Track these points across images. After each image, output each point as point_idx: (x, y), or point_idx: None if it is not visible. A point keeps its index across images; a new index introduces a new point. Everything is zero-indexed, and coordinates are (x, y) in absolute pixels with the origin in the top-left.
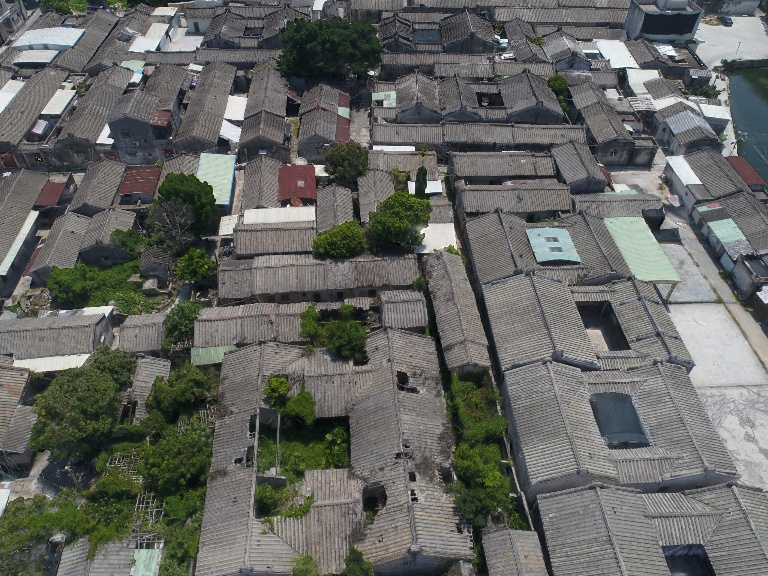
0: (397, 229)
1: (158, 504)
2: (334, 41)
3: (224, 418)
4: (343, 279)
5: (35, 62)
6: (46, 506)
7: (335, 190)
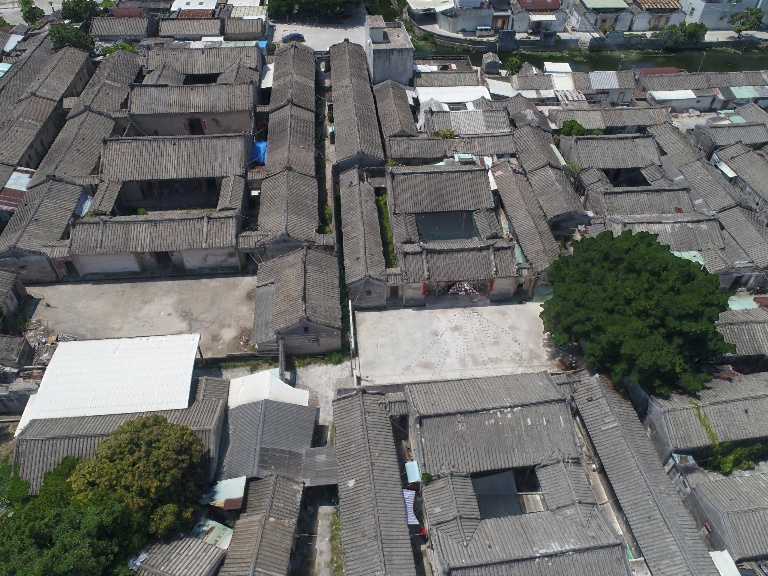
0: None
1: None
2: None
3: None
4: None
5: None
6: None
7: None
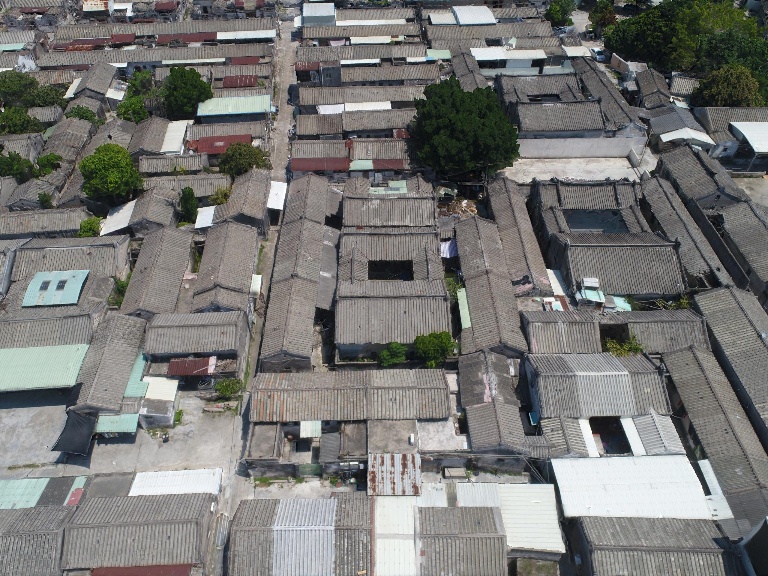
0: None
1: None
2: None
3: None
4: None
5: (431, 19)
6: None
7: (194, 156)
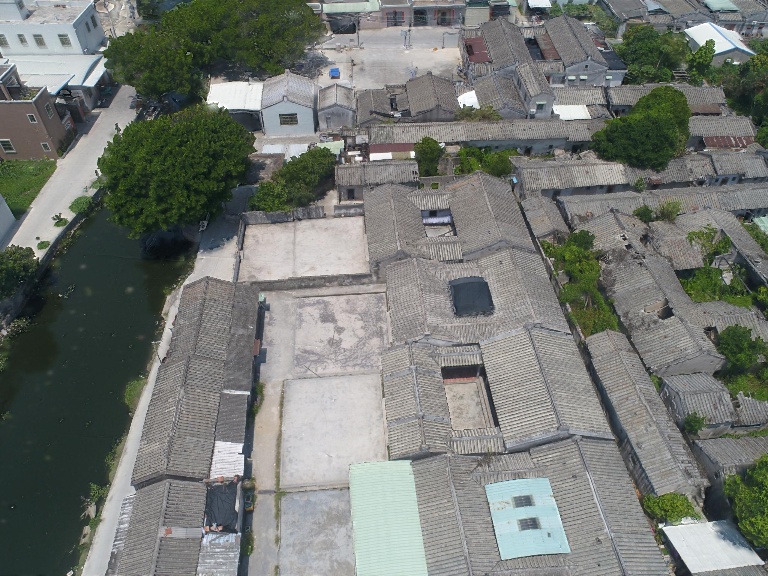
0: None
1: None
2: None
3: None
4: None
5: None
6: None
7: None
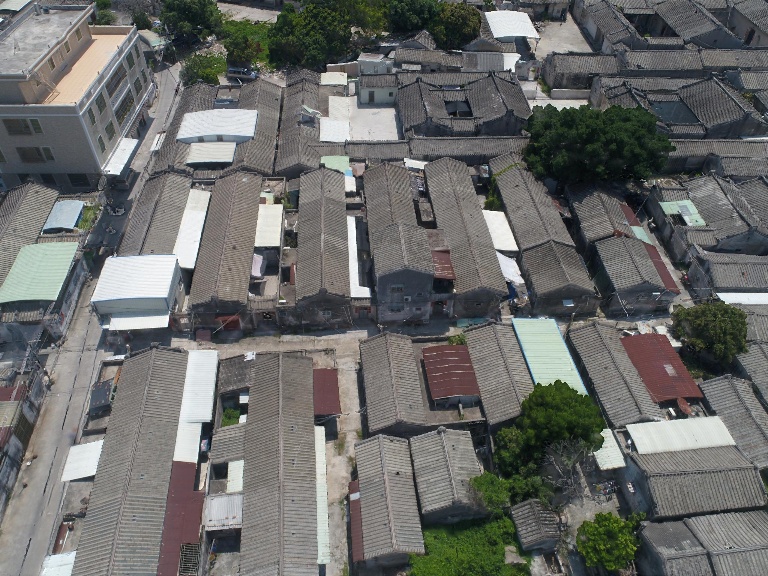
0: None
1: None
2: (623, 140)
3: None
4: None
5: (214, 162)
6: None
7: (735, 386)
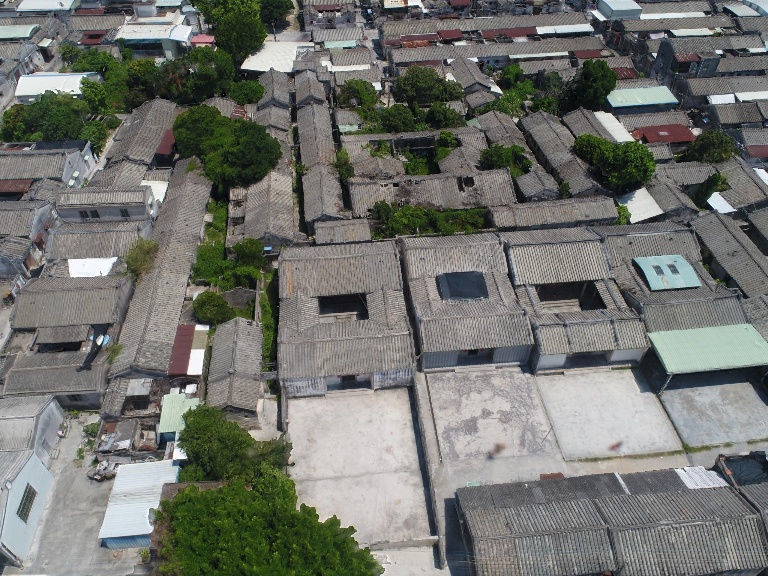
0: (602, 154)
1: (379, 125)
2: None
3: (428, 131)
4: (558, 159)
5: (733, 12)
6: (370, 91)
7: (661, 145)
